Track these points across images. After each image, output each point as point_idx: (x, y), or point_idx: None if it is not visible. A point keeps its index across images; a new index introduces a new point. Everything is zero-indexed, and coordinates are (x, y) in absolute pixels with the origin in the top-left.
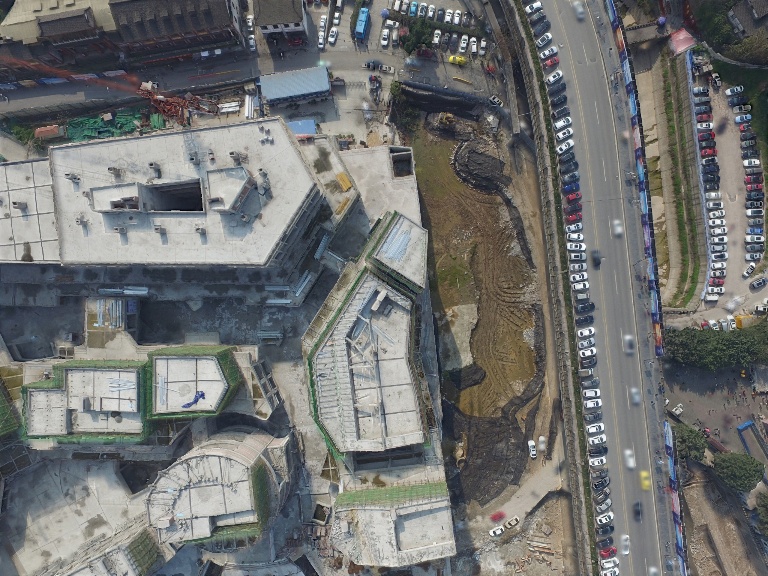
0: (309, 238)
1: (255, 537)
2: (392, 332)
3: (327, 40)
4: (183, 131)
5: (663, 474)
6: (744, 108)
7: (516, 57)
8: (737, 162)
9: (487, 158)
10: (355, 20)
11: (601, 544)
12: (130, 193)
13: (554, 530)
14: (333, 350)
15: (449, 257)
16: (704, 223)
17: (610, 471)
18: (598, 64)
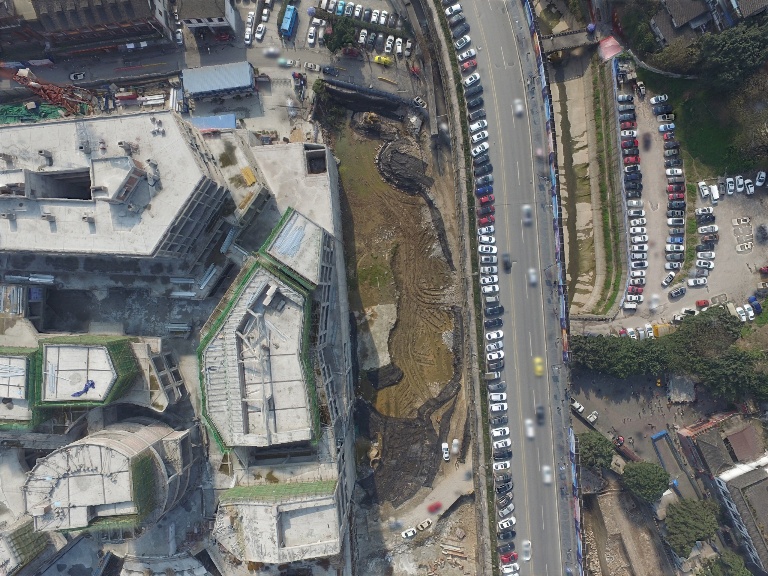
0: (212, 231)
1: (142, 529)
2: (285, 328)
3: (254, 36)
4: (76, 120)
5: (567, 480)
6: (667, 117)
7: (435, 58)
8: (660, 171)
9: (410, 159)
10: (282, 17)
11: (502, 549)
12: (17, 179)
13: (468, 534)
14: (224, 344)
15: (370, 256)
16: (625, 231)
17: (514, 476)
18: (516, 68)
